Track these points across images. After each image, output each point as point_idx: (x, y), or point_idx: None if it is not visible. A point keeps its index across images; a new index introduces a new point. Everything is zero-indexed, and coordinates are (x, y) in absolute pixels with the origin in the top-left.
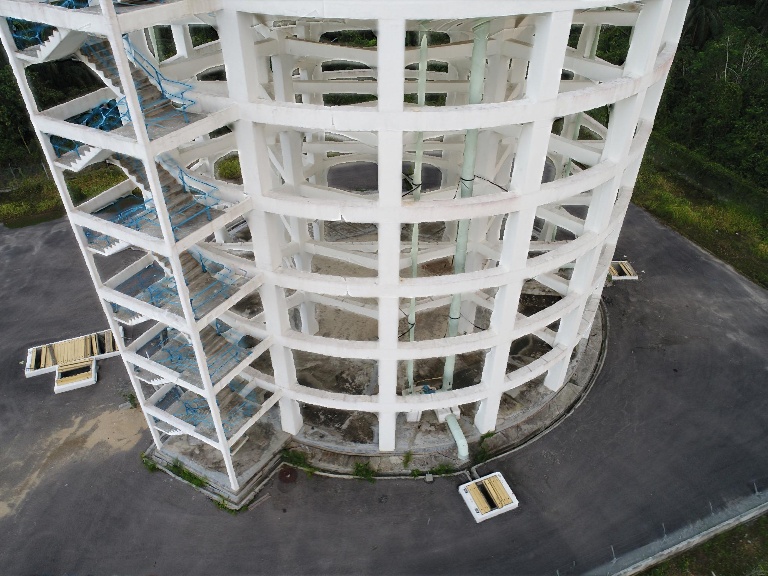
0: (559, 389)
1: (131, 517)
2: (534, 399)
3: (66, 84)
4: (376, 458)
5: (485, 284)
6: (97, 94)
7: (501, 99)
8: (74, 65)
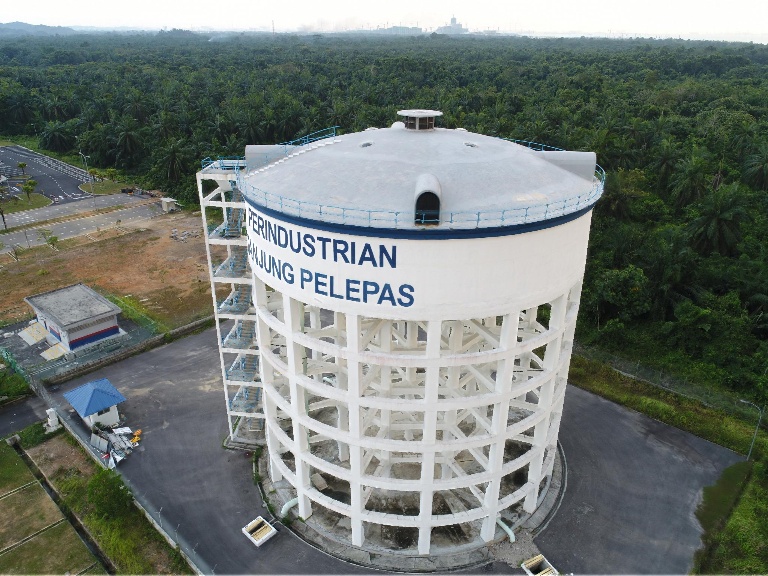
0: (357, 546)
1: (213, 420)
2: (340, 534)
3: None
4: (269, 480)
5: None
6: None
7: (387, 343)
8: None
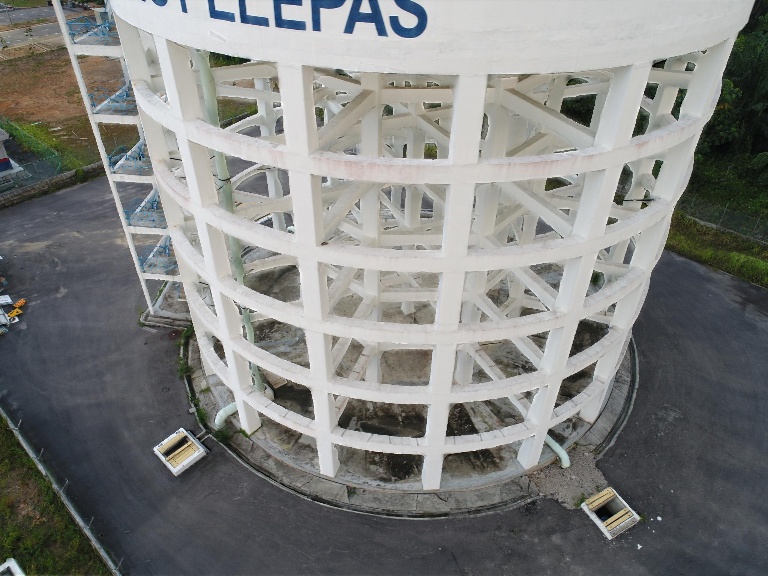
0: (328, 476)
1: (129, 285)
2: (302, 457)
3: None
4: (201, 372)
5: None
6: None
7: (373, 152)
8: None
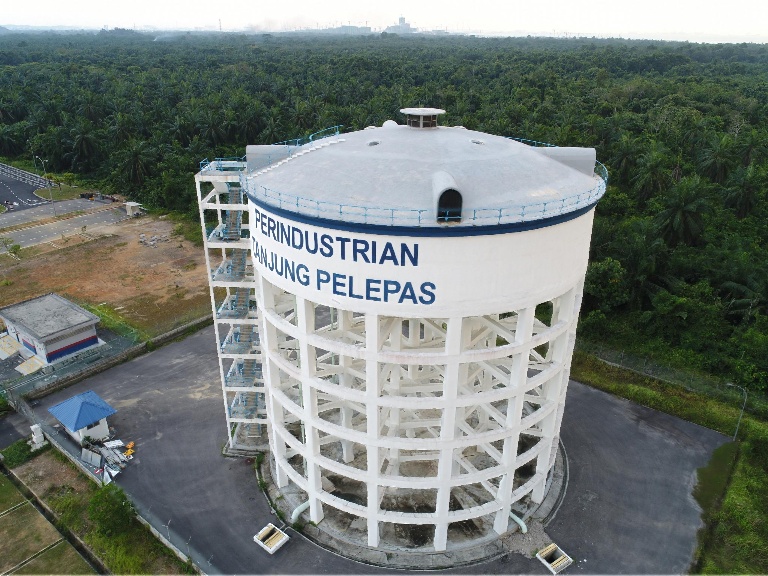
0: (373, 547)
1: (208, 428)
2: (354, 536)
3: None
4: (274, 486)
5: (295, 413)
6: (251, 261)
7: (397, 341)
8: None
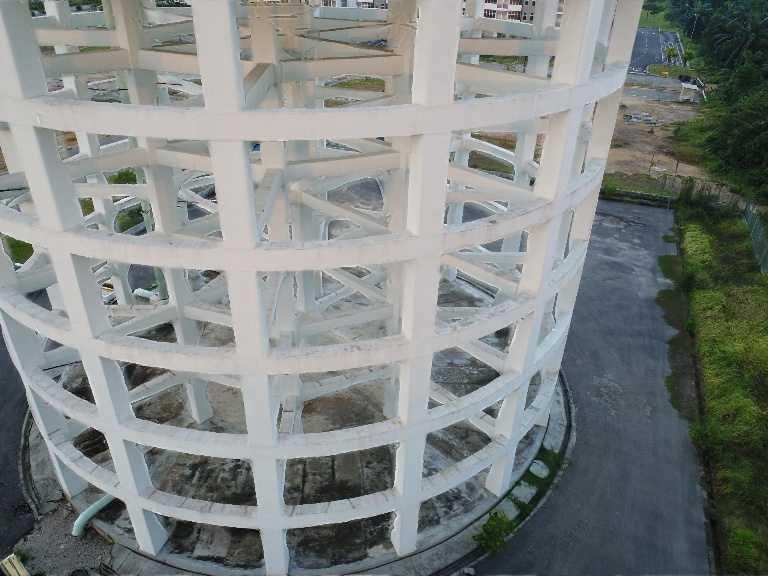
0: None
1: None
2: None
3: None
4: None
5: None
6: None
7: None
8: None
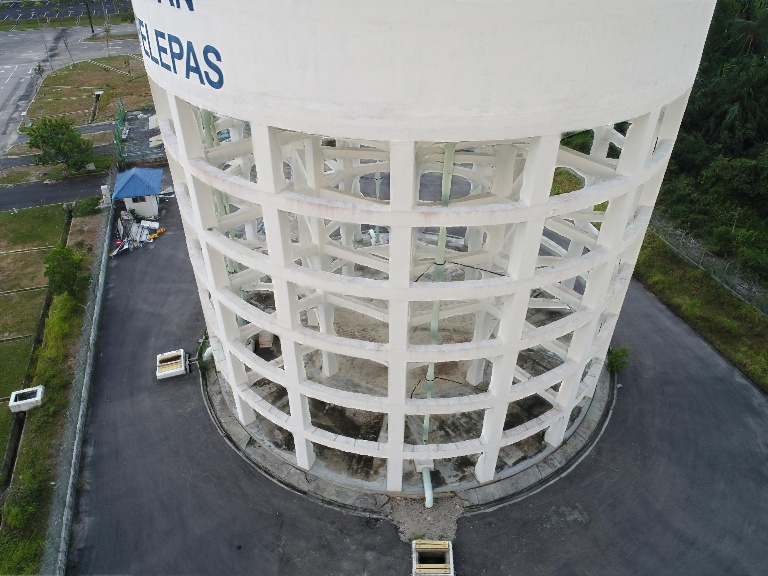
0: None
1: None
2: None
3: (700, 129)
4: None
5: None
6: None
7: None
8: (721, 119)
